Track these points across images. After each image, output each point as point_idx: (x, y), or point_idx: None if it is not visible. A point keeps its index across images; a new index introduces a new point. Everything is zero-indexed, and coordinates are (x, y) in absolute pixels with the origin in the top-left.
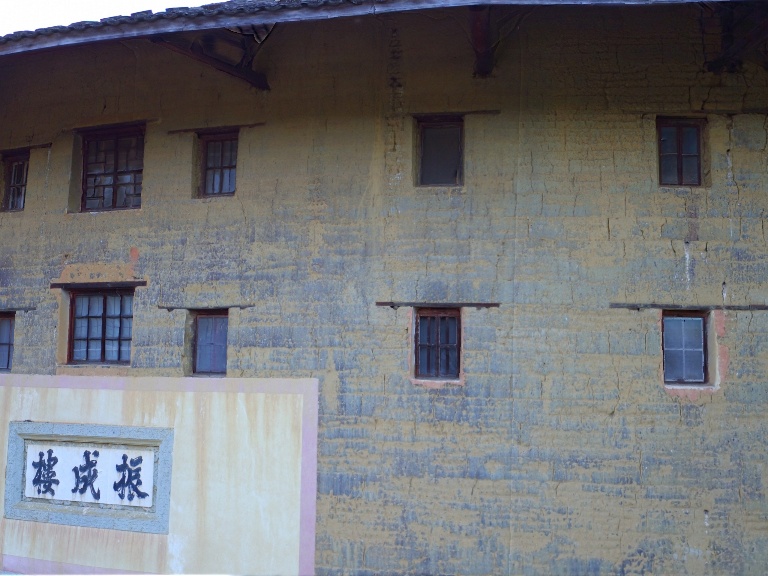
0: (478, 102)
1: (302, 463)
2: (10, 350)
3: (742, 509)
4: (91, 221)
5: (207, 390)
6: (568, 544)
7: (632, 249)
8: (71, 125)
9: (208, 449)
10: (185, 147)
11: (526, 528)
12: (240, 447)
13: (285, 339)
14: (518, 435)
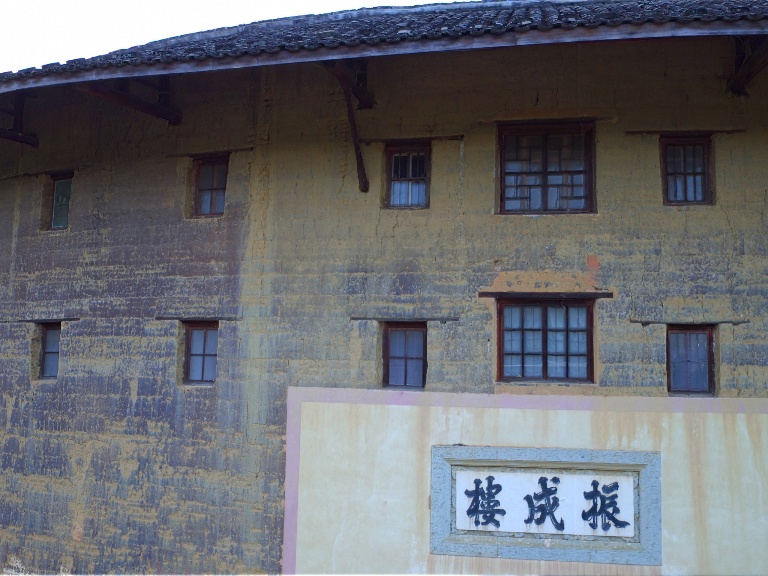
0: None
1: None
2: (407, 364)
3: None
4: (531, 224)
5: (700, 411)
6: None
7: None
8: (491, 117)
9: (705, 473)
10: (650, 150)
11: None
12: (743, 471)
13: None
14: None
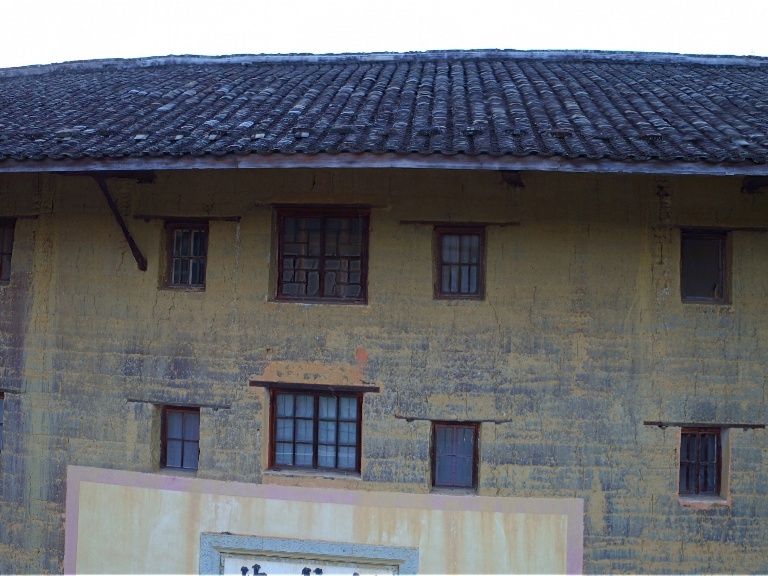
0: (746, 218)
1: None
2: (184, 447)
3: None
4: (302, 314)
5: (458, 509)
6: None
7: None
8: (267, 199)
9: (461, 570)
10: (423, 241)
11: None
12: (498, 569)
13: (547, 457)
14: None
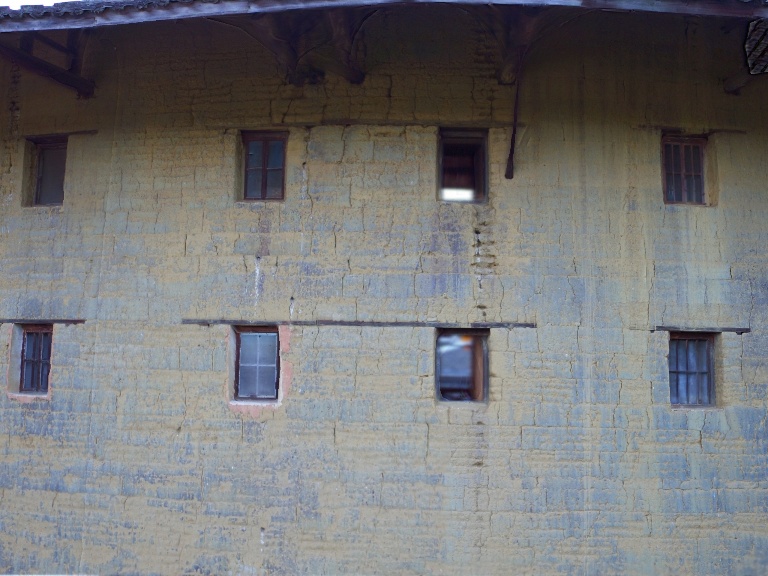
0: (80, 123)
1: None
2: None
3: (297, 528)
4: None
5: None
6: (131, 558)
7: (205, 265)
8: None
9: None
10: None
11: (95, 541)
12: None
13: None
14: (94, 449)
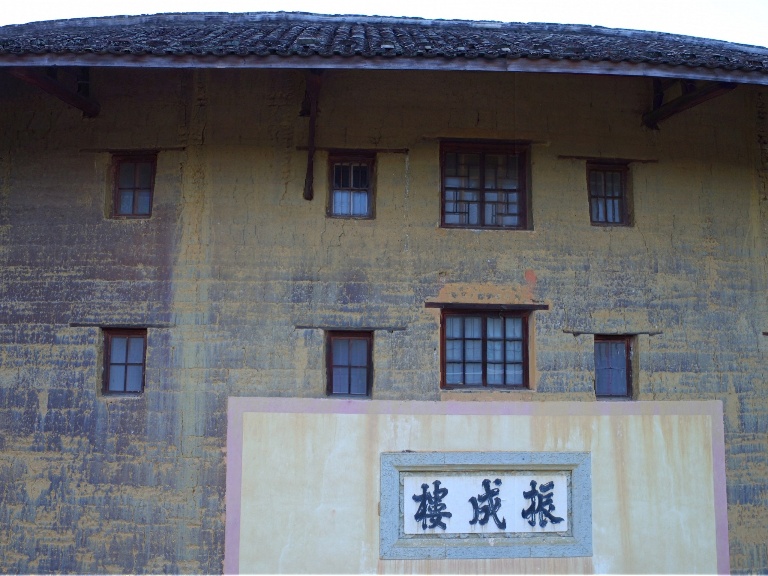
0: None
1: (714, 478)
2: (351, 373)
3: None
4: (473, 239)
5: (623, 413)
6: None
7: None
8: (434, 133)
9: (628, 470)
10: (579, 174)
11: None
12: (659, 466)
13: (692, 364)
14: None
